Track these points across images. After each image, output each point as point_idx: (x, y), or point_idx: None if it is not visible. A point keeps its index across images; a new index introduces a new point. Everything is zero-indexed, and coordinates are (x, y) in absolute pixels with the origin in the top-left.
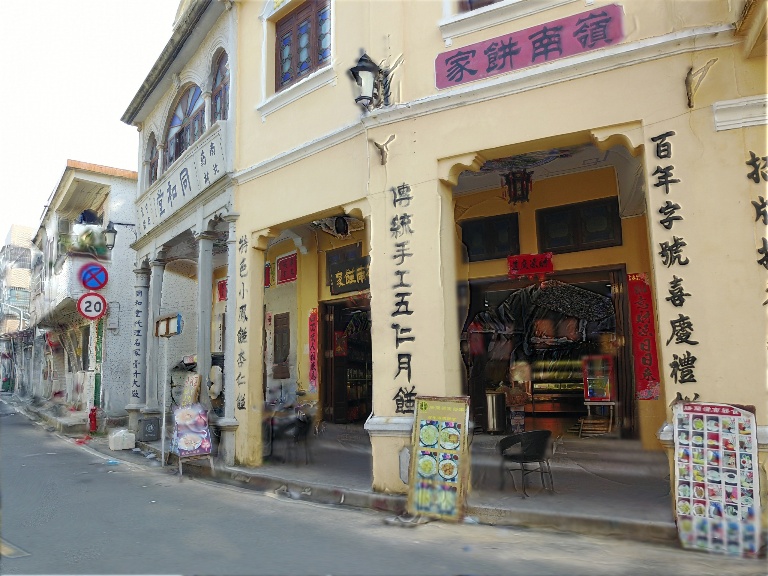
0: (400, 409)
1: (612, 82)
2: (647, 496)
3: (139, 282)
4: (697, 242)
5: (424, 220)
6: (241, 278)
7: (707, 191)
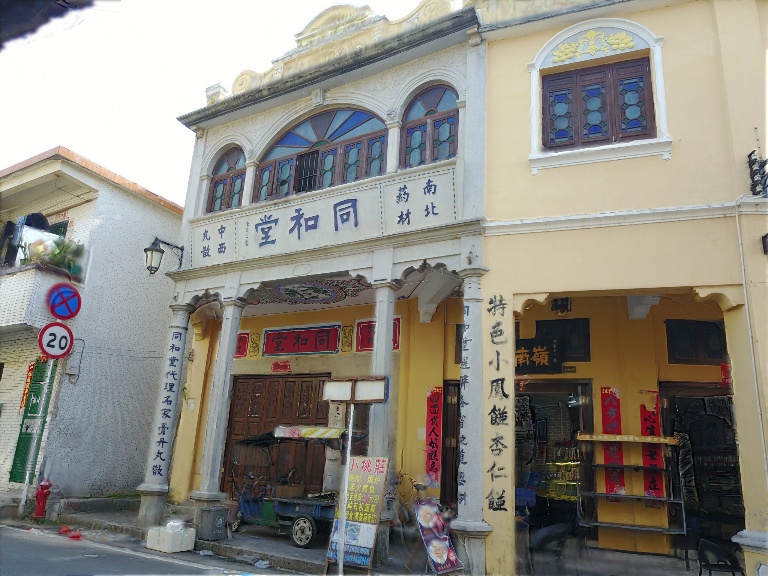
0: None
1: None
2: None
3: (179, 321)
4: None
5: None
6: (494, 345)
7: None
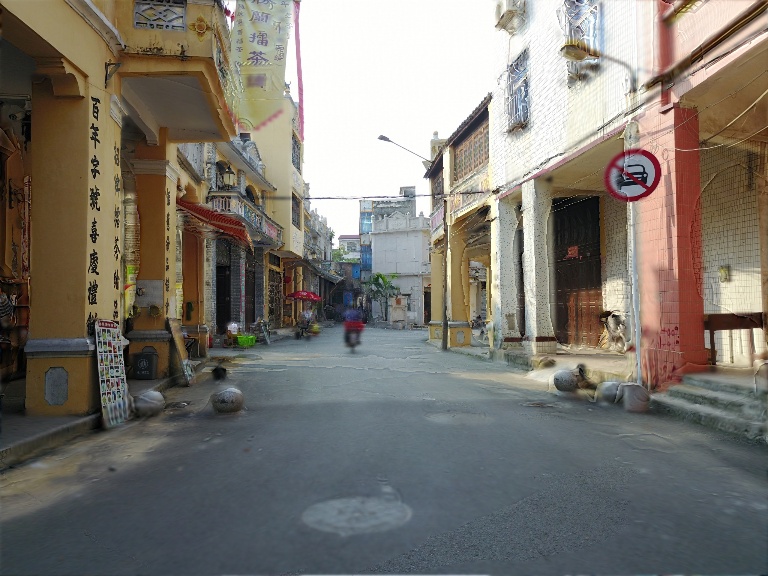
0: None
1: (79, 26)
2: (3, 415)
3: None
4: None
5: None
6: None
7: None
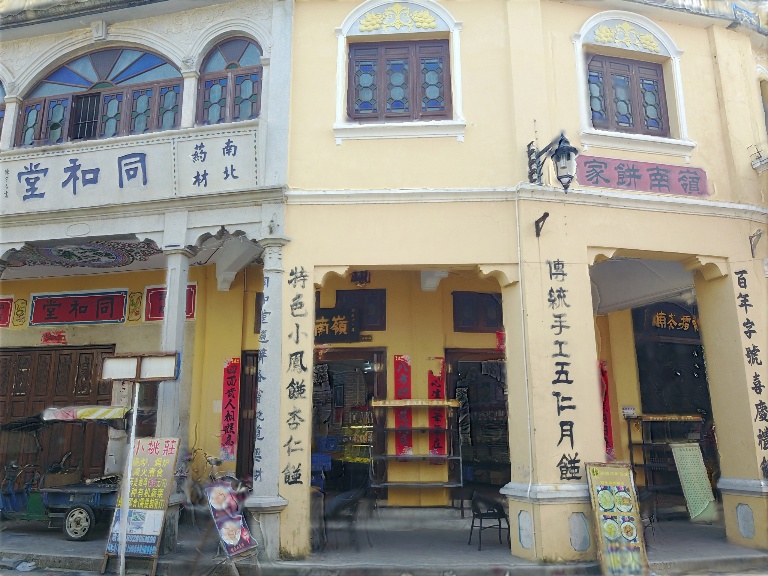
0: (564, 476)
1: (710, 225)
2: None
3: None
4: (765, 350)
5: (579, 297)
6: (294, 318)
7: (766, 316)
